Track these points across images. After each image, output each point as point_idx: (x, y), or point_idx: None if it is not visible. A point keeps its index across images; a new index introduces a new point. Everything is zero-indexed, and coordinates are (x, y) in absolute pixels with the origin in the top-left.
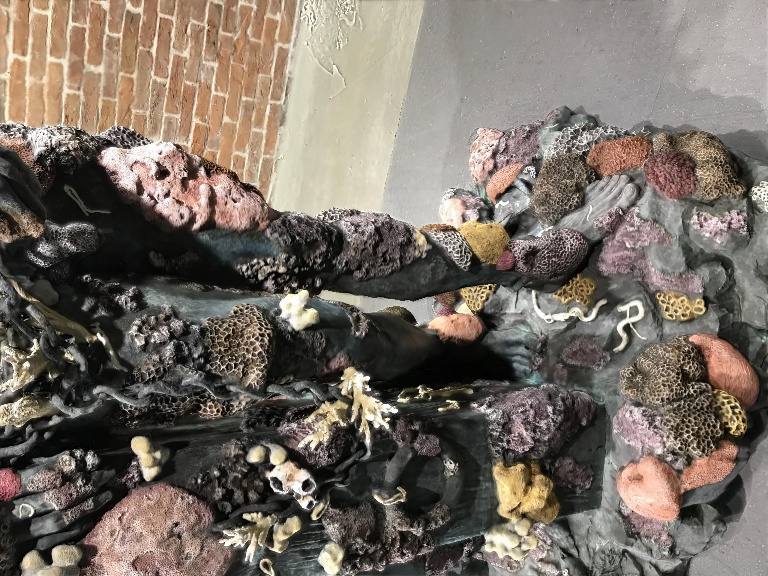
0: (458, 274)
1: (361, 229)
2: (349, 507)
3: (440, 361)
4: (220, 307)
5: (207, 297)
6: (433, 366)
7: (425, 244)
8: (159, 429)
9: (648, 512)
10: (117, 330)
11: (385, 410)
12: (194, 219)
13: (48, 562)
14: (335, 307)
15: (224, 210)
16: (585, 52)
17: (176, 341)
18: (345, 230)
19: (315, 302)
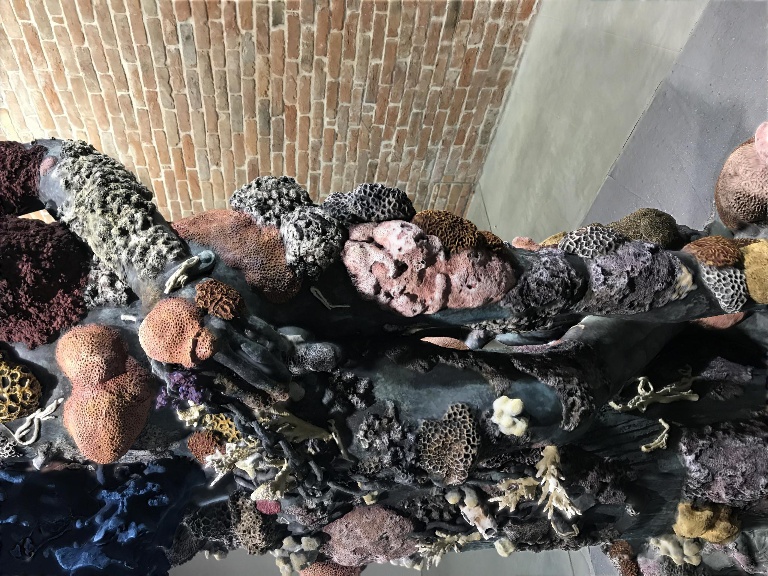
0: (721, 311)
1: (611, 282)
2: (527, 523)
3: (680, 336)
4: (437, 403)
5: (429, 383)
6: (667, 350)
7: (689, 285)
8: None
9: None
10: (348, 429)
11: (569, 513)
12: (426, 309)
13: (299, 543)
14: (551, 395)
15: (457, 296)
16: None
17: (393, 449)
18: (593, 277)
19: (531, 391)
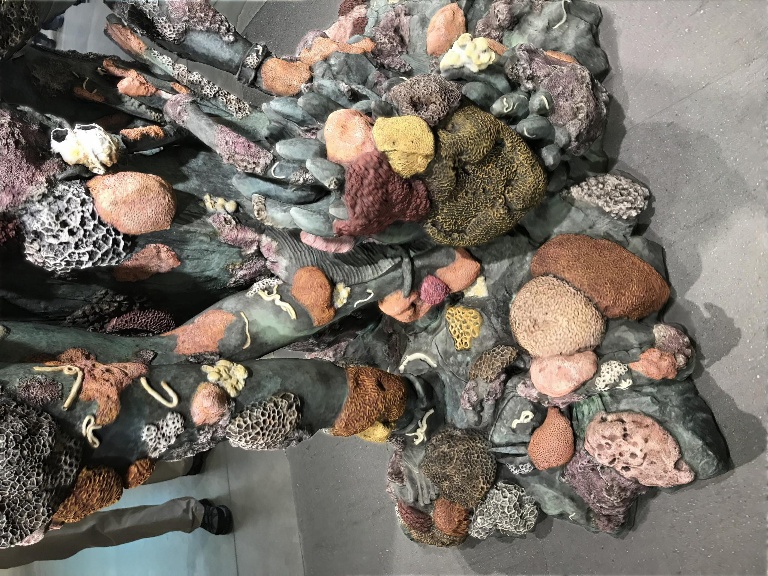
0: None
1: None
2: None
3: None
4: None
5: None
6: None
7: None
8: (5, 301)
9: None
10: None
11: None
12: None
13: None
14: None
15: None
16: None
17: None
18: None
19: None
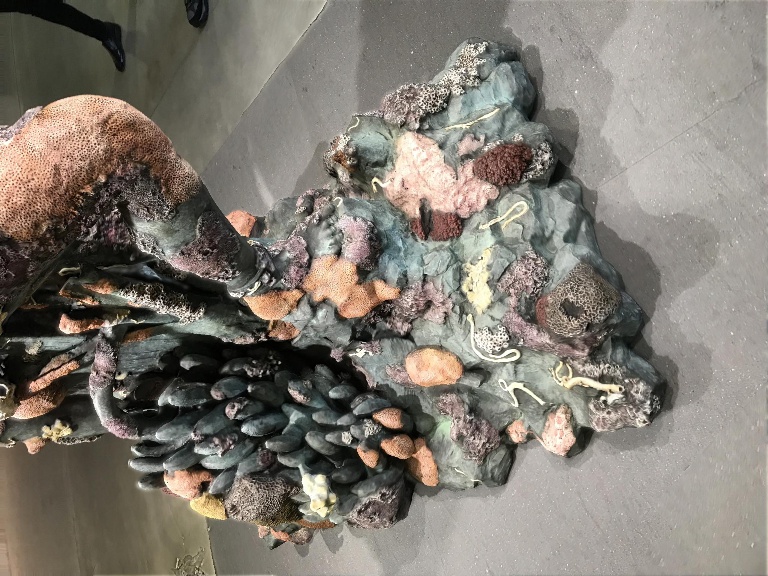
0: None
1: None
2: None
3: None
4: None
5: None
6: None
7: None
8: None
9: (237, 218)
10: None
11: None
12: None
13: None
14: None
15: None
16: None
17: None
18: None
19: None
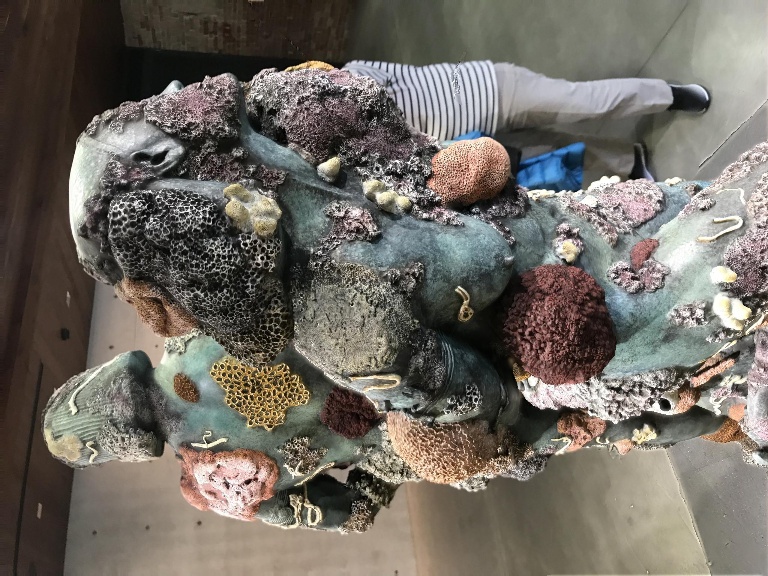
0: None
1: None
2: None
3: None
4: None
5: None
6: None
7: None
8: None
9: None
10: None
11: None
12: None
13: None
14: None
15: None
16: (767, 522)
17: None
18: None
19: None
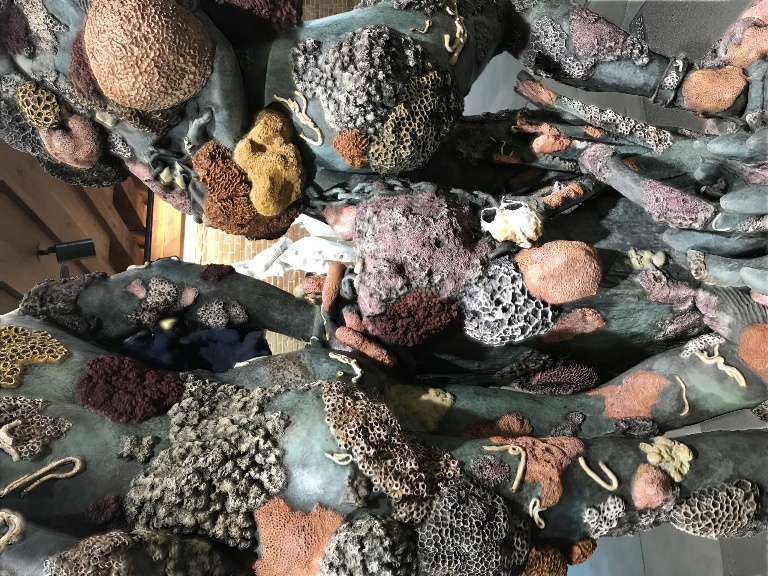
0: None
1: None
2: None
3: None
4: None
5: None
6: None
7: None
8: (447, 362)
9: None
10: None
11: None
12: None
13: None
14: None
15: None
16: None
17: None
18: None
19: None
